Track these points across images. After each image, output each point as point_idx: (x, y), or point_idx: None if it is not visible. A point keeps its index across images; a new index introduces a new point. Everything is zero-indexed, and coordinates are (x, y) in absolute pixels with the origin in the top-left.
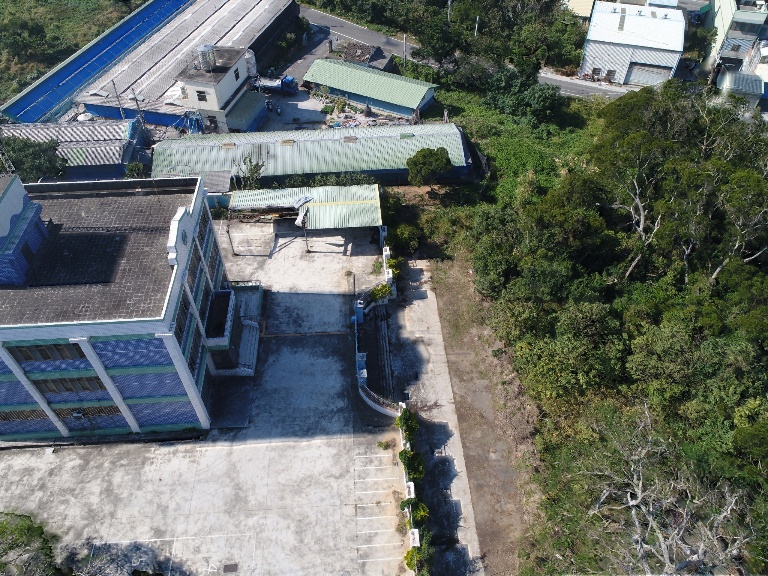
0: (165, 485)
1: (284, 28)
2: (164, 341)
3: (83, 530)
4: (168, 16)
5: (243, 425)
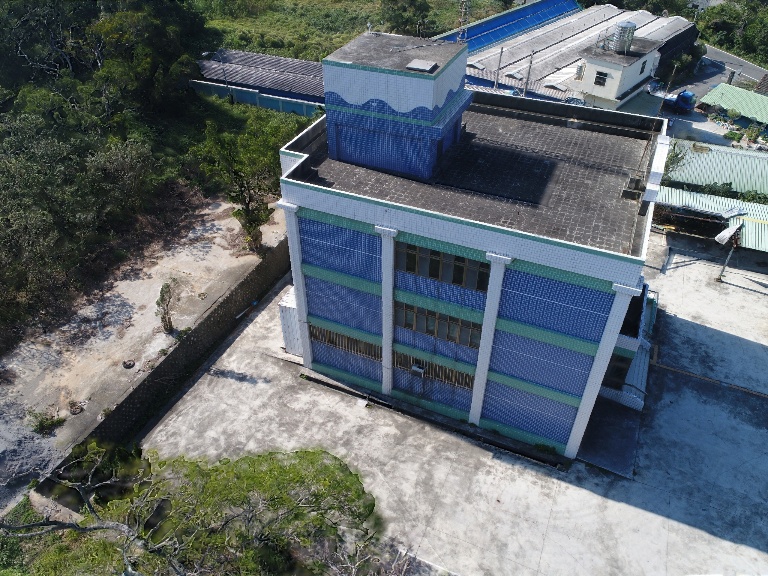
0: (505, 511)
1: (678, 50)
2: (616, 300)
3: (388, 524)
4: (550, 18)
5: (625, 474)
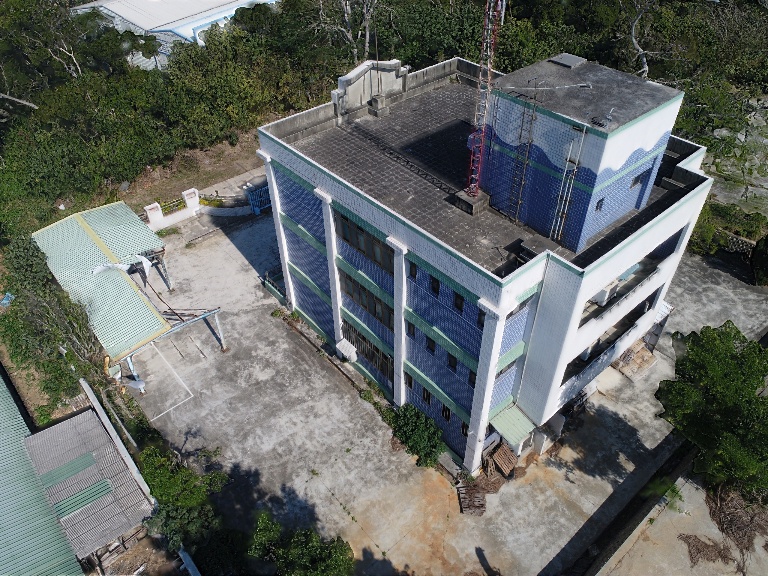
0: None
1: None
2: None
3: None
4: None
5: None
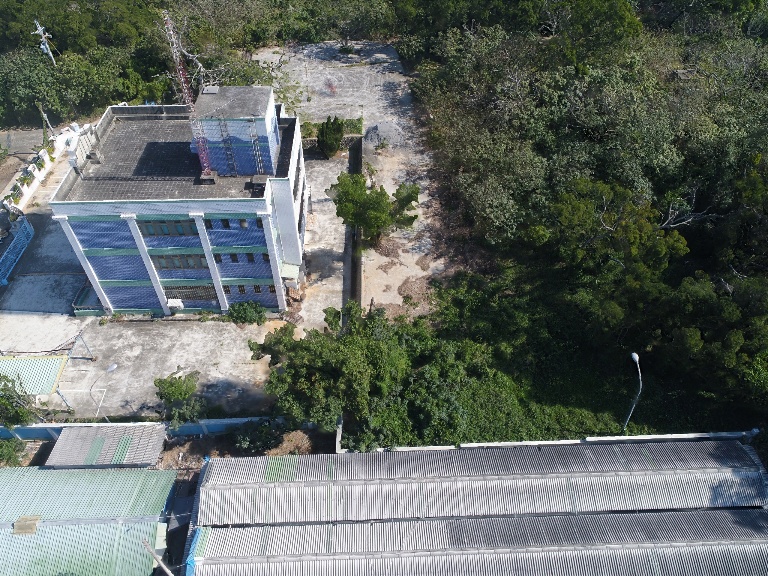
0: None
1: None
2: None
3: None
4: None
5: None
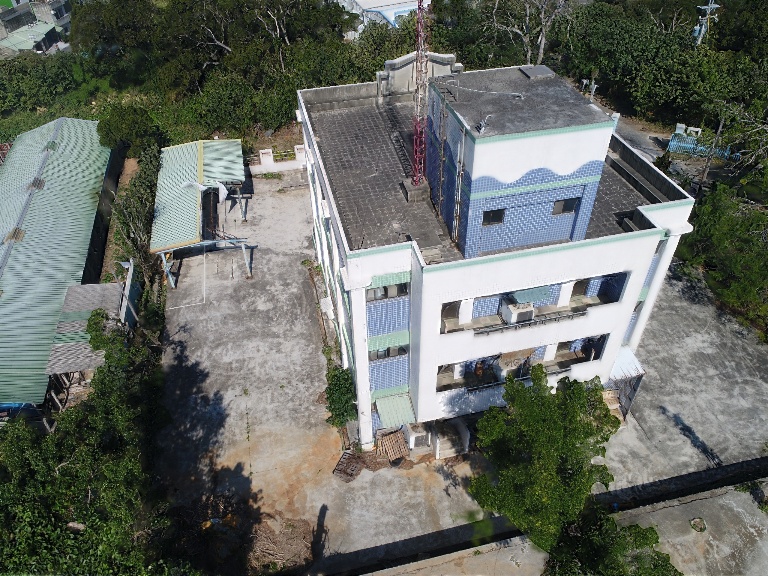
0: None
1: None
2: None
3: None
4: None
5: None
